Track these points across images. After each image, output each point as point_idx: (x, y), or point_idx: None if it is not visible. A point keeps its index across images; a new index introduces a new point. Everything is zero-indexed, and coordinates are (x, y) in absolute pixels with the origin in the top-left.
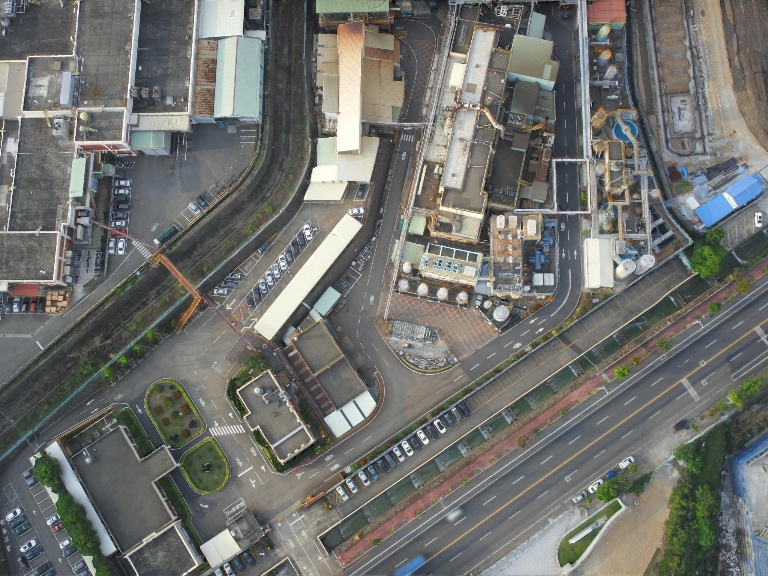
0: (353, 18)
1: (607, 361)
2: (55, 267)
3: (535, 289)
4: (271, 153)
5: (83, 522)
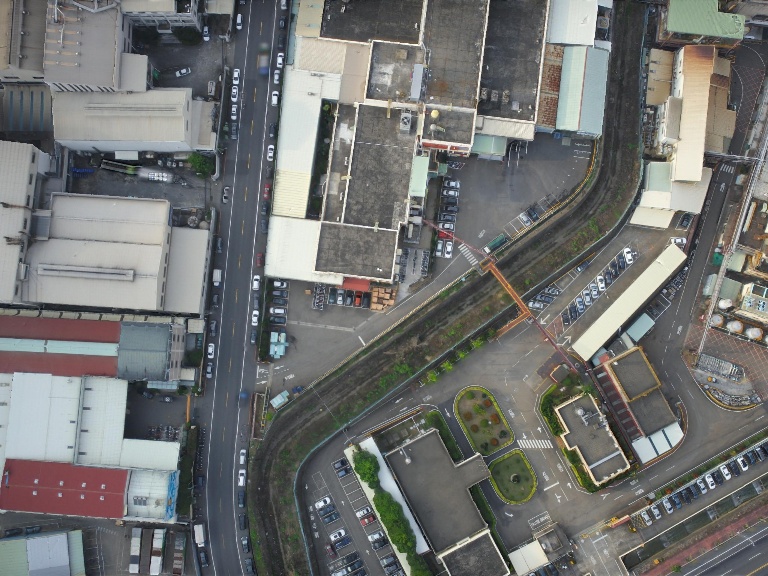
0: (700, 40)
1: None
2: (394, 267)
3: None
4: (600, 170)
5: (403, 521)
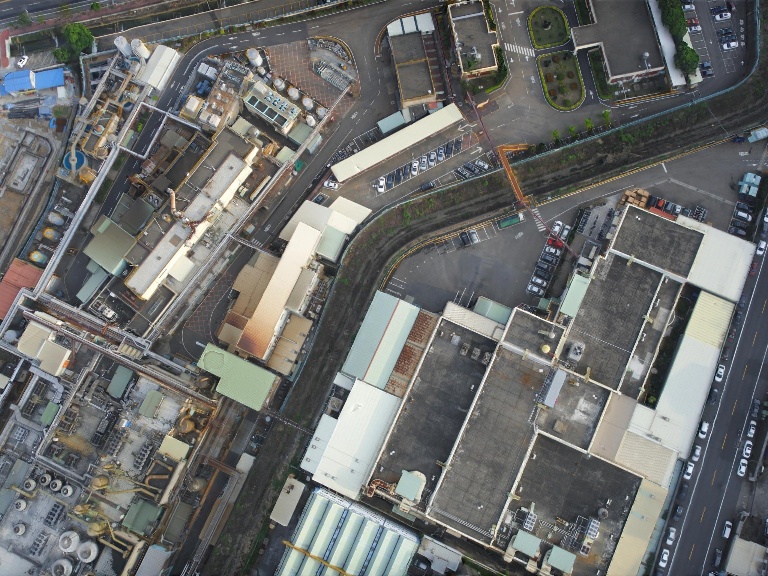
0: None
1: (196, 1)
2: (624, 216)
3: (219, 70)
4: None
5: (665, 6)
